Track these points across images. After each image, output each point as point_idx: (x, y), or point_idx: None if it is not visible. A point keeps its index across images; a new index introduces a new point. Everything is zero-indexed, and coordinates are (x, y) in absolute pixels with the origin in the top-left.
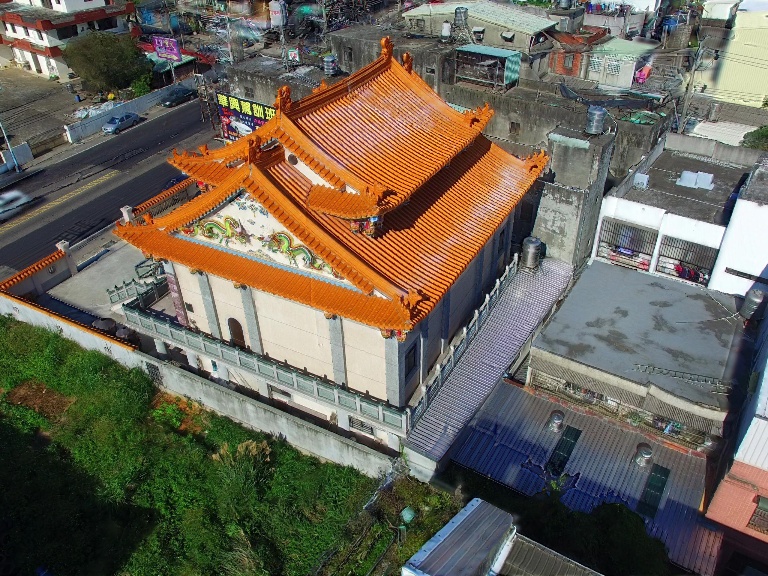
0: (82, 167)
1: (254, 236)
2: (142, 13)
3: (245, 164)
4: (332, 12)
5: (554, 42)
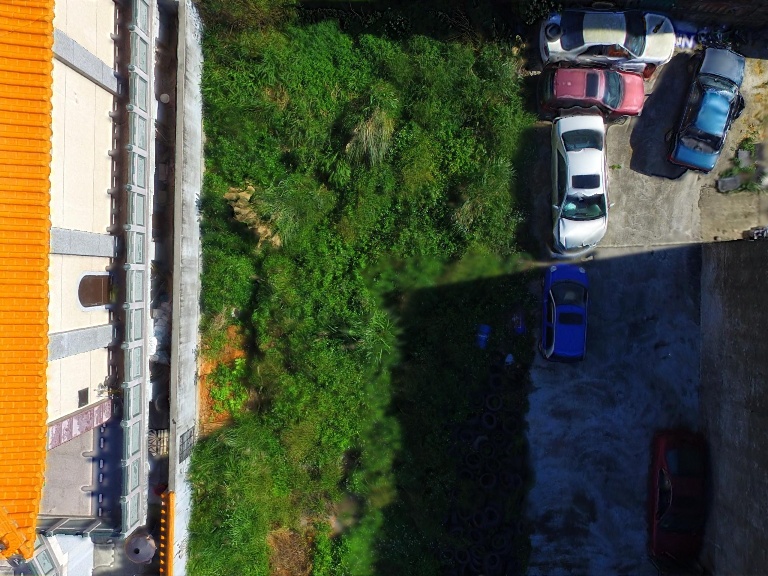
0: None
1: None
2: None
3: None
4: None
5: None
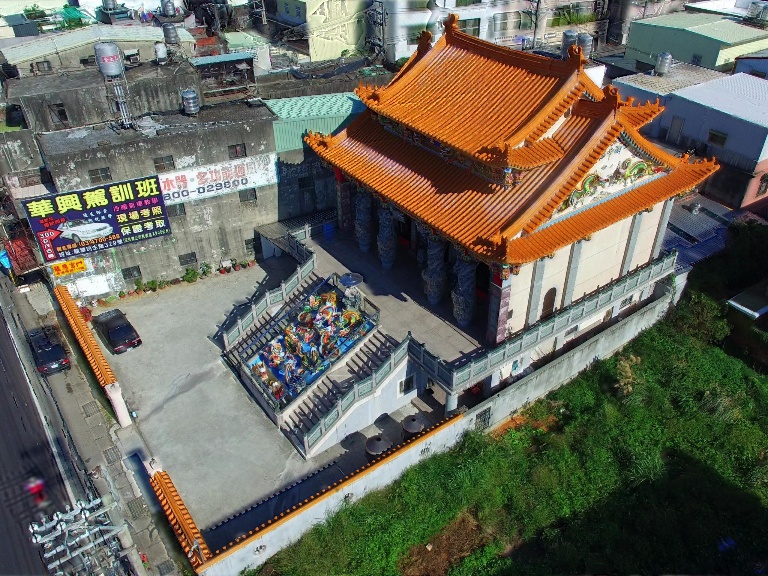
0: None
1: None
2: None
3: (618, 111)
4: None
5: (248, 38)
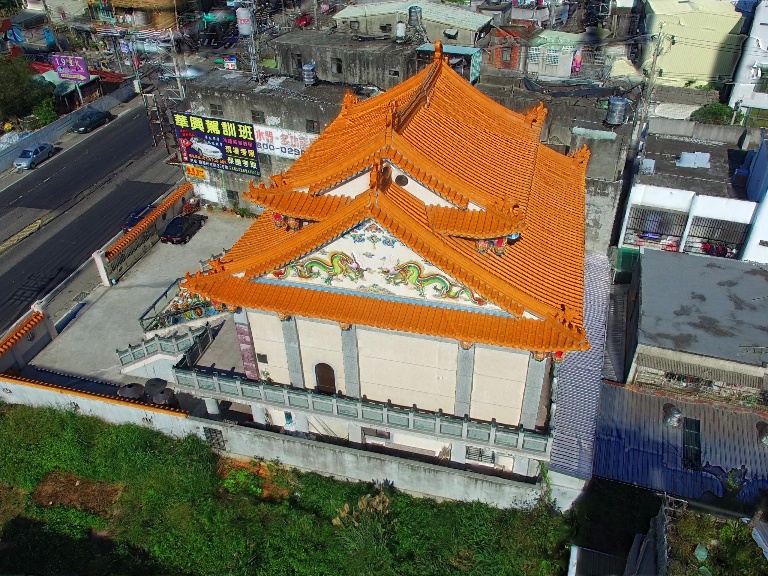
0: (6, 211)
1: (370, 270)
2: (20, 30)
3: (371, 191)
4: (261, 18)
5: (508, 37)
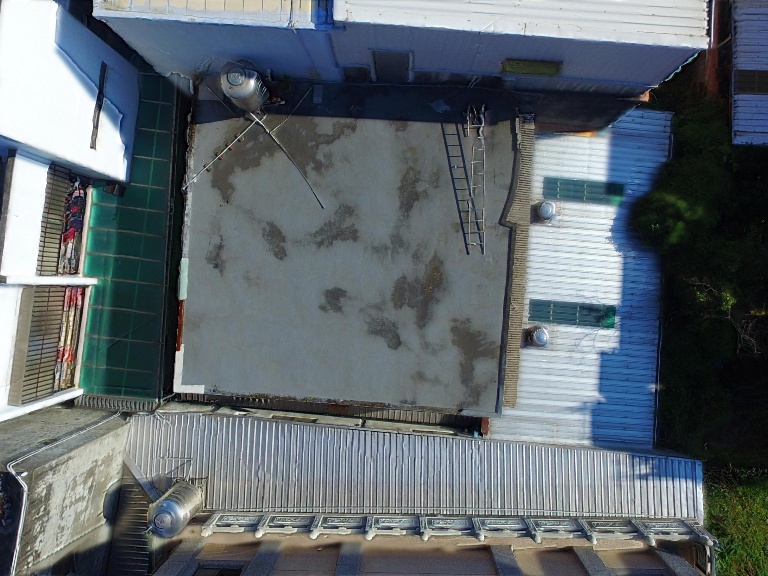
0: None
1: None
2: None
3: None
4: None
5: None
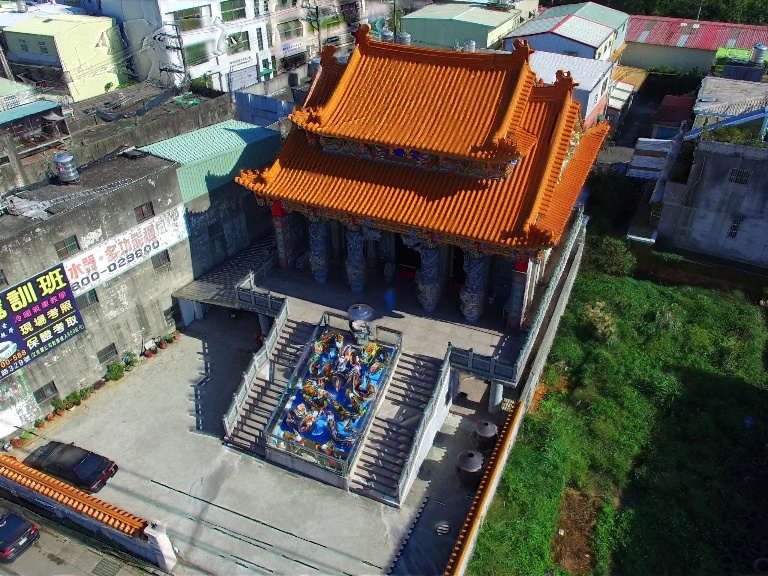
0: None
1: None
2: None
3: None
4: None
5: (30, 84)
